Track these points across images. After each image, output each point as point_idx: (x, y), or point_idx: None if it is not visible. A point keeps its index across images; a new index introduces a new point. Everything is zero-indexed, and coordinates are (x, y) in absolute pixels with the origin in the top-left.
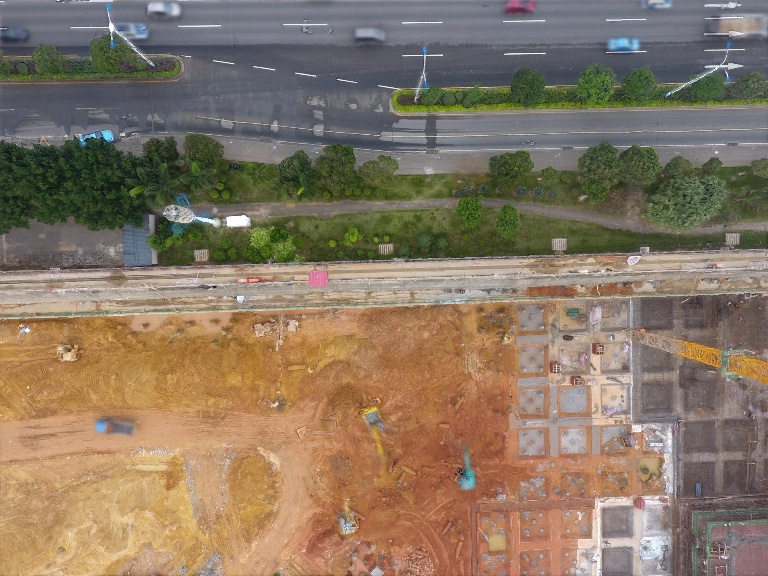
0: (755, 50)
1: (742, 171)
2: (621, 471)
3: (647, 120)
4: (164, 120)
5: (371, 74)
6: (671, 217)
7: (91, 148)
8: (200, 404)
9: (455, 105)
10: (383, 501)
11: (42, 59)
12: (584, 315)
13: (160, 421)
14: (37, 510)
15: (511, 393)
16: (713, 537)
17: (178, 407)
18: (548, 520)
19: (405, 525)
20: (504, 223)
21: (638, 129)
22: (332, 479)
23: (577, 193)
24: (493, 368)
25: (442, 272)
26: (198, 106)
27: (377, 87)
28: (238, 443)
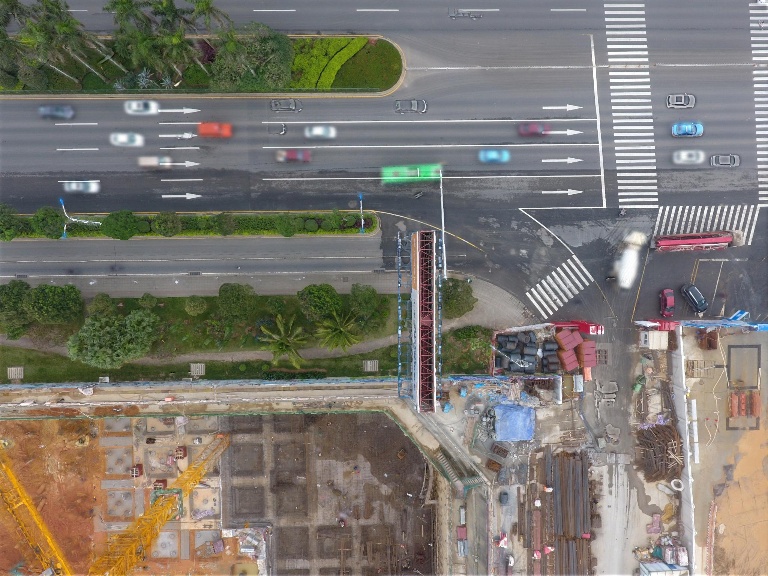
0: (214, 180)
1: None
2: None
3: (104, 249)
4: None
5: None
6: None
7: None
8: None
9: None
10: None
11: None
12: None
13: None
14: None
15: (95, 495)
16: None
17: None
18: None
19: None
20: None
21: (94, 258)
22: None
23: None
24: (75, 470)
25: None
26: None
27: None
28: None
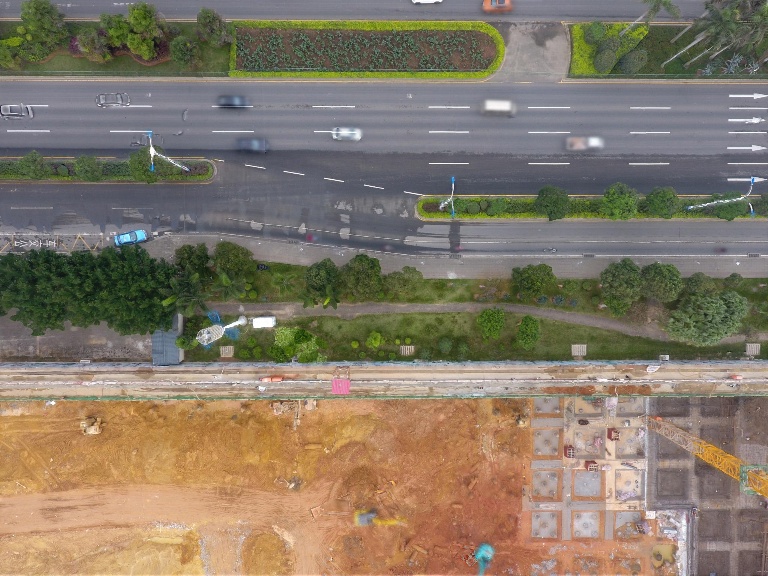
0: None
1: (763, 283)
2: (634, 557)
3: (669, 230)
4: (196, 221)
5: (398, 180)
6: (692, 334)
7: (127, 258)
8: (217, 481)
9: (479, 213)
10: None
11: (83, 170)
12: (600, 399)
13: (178, 496)
14: None
15: (525, 475)
16: None
17: (196, 483)
18: None
19: None
20: (525, 336)
21: (660, 239)
22: (344, 559)
23: (598, 302)
24: (507, 450)
25: (462, 375)
26: (229, 208)
27: (403, 193)
28: (253, 520)
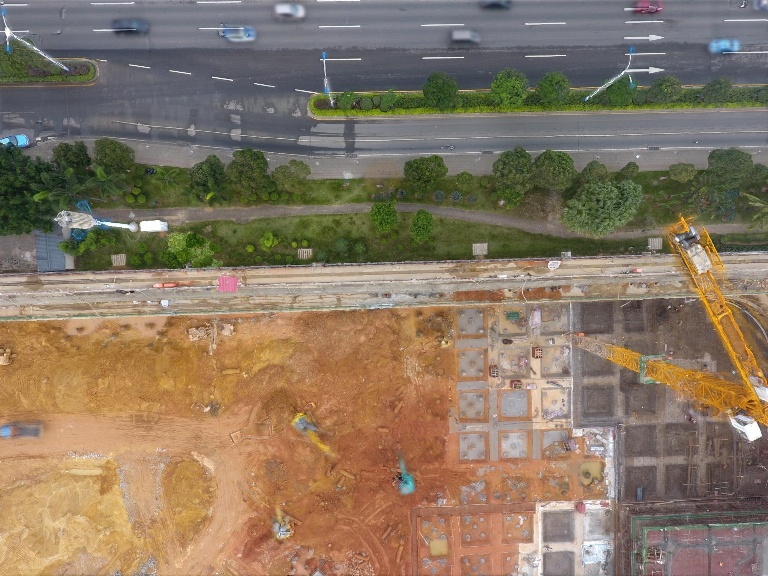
0: (676, 54)
1: (663, 175)
2: (562, 475)
3: (568, 124)
4: (80, 124)
5: (288, 78)
6: (585, 222)
7: None
8: (133, 408)
9: (372, 109)
10: (321, 505)
11: None
12: (524, 319)
13: (93, 425)
14: None
15: (451, 397)
16: (649, 542)
17: (111, 411)
18: (489, 524)
19: (344, 529)
20: (417, 228)
21: (558, 133)
22: (267, 484)
23: (496, 198)
24: (432, 372)
25: (361, 277)
26: (114, 110)
27: (295, 91)
28: (172, 447)
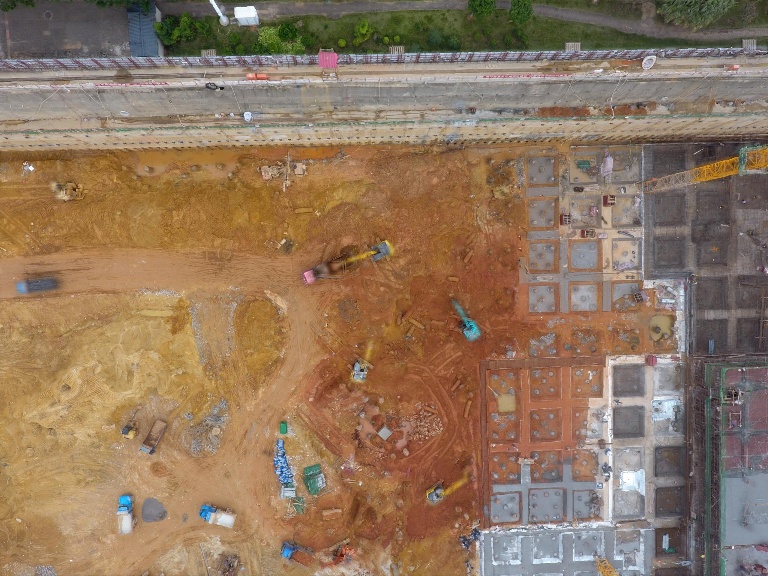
0: None
1: None
2: (632, 328)
3: None
4: None
5: None
6: (688, 3)
7: None
8: (206, 245)
9: None
10: (391, 354)
11: None
12: (595, 167)
13: (166, 261)
14: (41, 354)
15: (521, 247)
16: (727, 383)
17: (184, 247)
18: (558, 378)
19: (413, 379)
20: (517, 7)
21: None
22: (340, 324)
23: None
24: (503, 220)
25: (453, 75)
26: None
27: None
28: (245, 286)
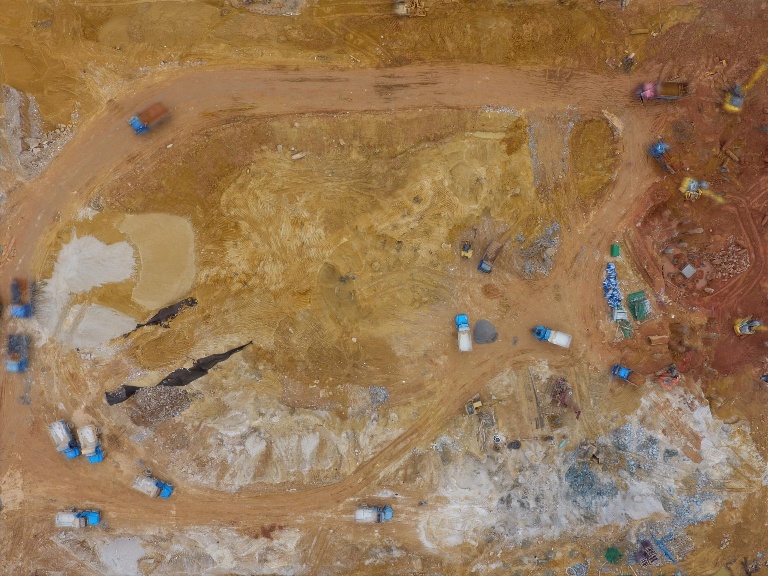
0: None
1: None
2: None
3: None
4: None
5: None
6: None
7: None
8: (547, 63)
9: None
10: (709, 184)
11: None
12: None
13: (508, 79)
14: (377, 174)
15: None
16: None
17: (525, 65)
18: None
19: (729, 211)
20: None
21: None
22: (673, 146)
23: None
24: None
25: None
26: None
27: None
28: (582, 105)
